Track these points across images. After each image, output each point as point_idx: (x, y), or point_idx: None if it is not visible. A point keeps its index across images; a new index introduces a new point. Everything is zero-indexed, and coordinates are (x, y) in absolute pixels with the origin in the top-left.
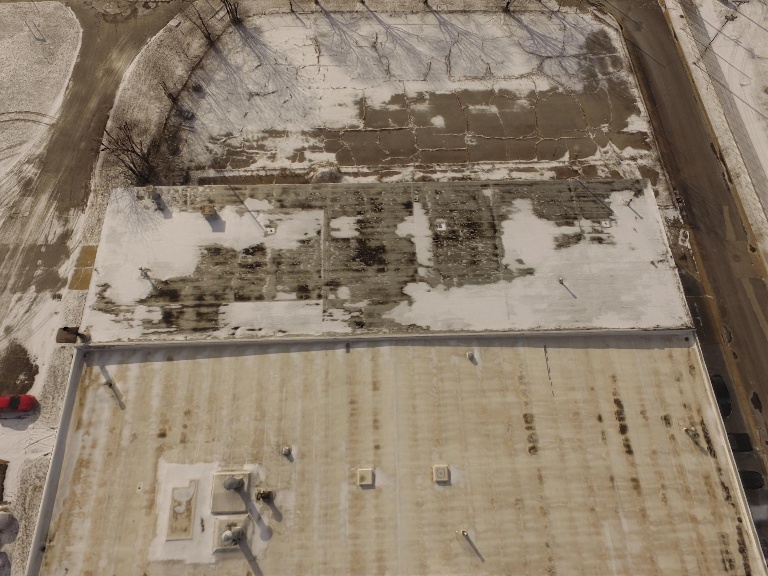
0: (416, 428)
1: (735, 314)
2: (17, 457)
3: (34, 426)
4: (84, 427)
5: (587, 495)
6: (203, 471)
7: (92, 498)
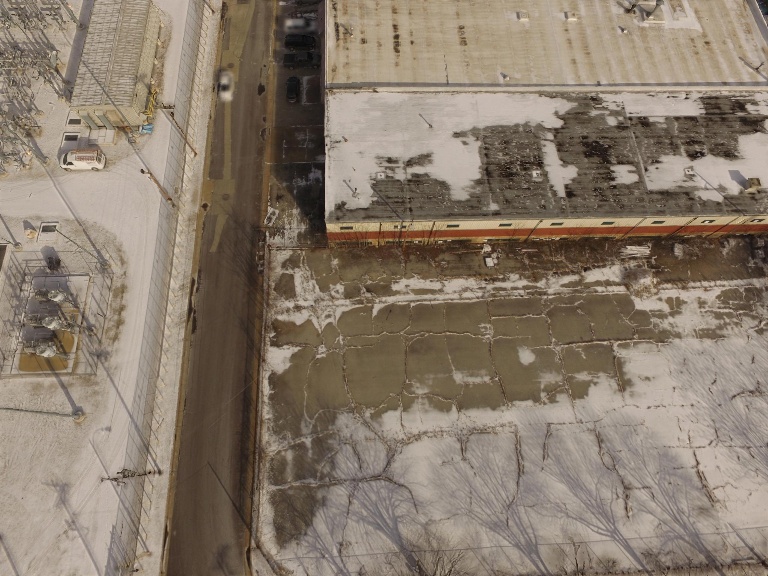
0: (542, 39)
1: (250, 149)
2: None
3: None
4: (759, 49)
5: (428, 7)
6: (673, 24)
7: (732, 17)
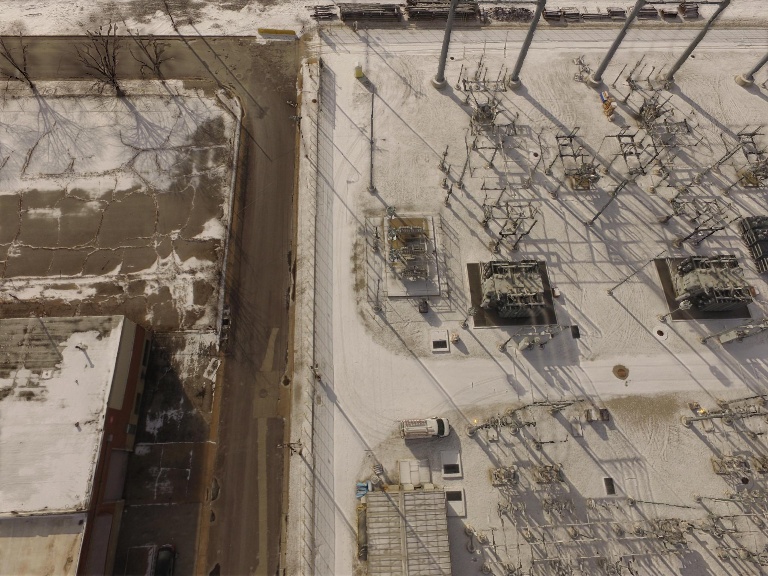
0: None
1: (233, 464)
2: None
3: None
4: None
5: None
6: None
7: None
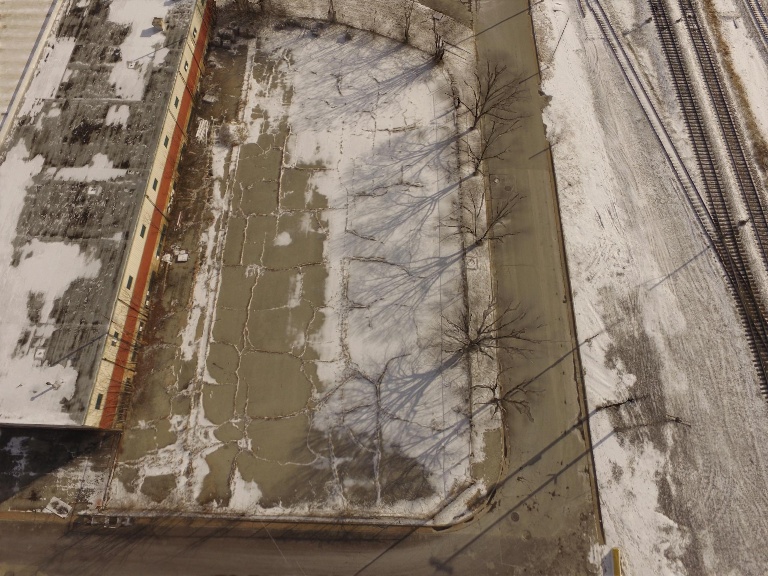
0: None
1: None
2: None
3: None
4: None
5: None
6: None
7: None
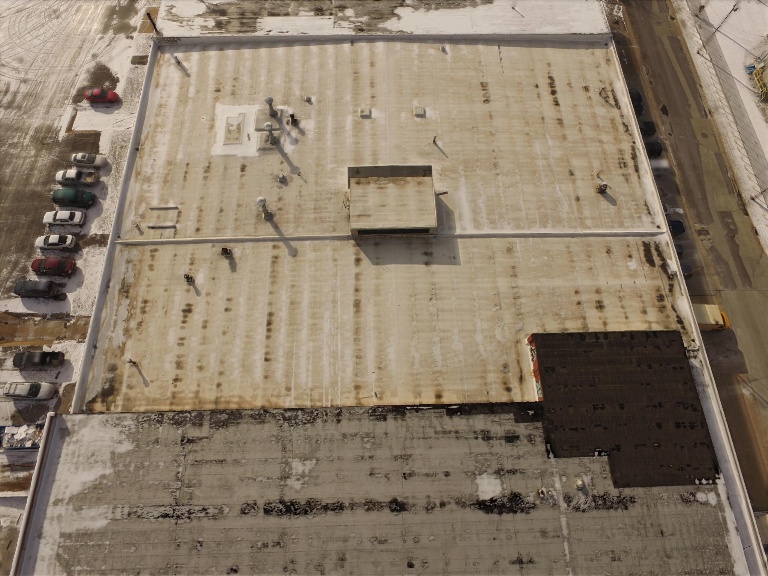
0: (402, 87)
1: (654, 58)
2: (107, 129)
3: (119, 112)
4: (161, 86)
5: (524, 126)
6: (248, 109)
7: (170, 123)
